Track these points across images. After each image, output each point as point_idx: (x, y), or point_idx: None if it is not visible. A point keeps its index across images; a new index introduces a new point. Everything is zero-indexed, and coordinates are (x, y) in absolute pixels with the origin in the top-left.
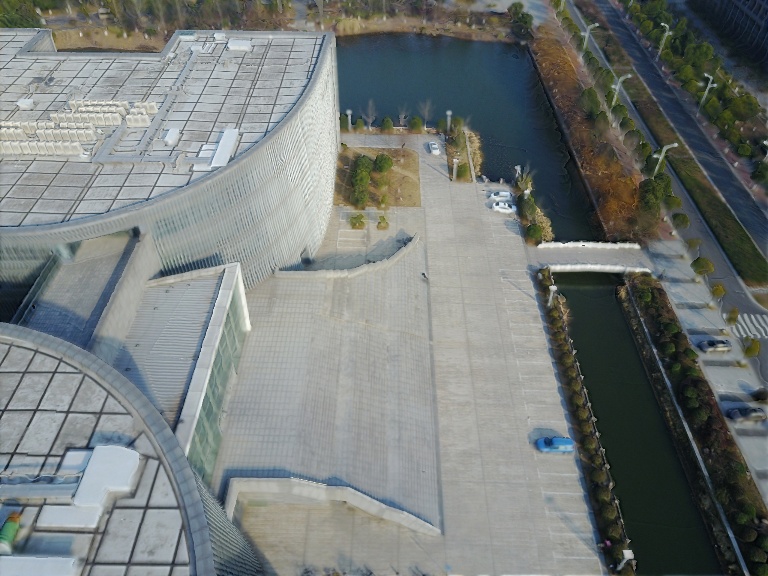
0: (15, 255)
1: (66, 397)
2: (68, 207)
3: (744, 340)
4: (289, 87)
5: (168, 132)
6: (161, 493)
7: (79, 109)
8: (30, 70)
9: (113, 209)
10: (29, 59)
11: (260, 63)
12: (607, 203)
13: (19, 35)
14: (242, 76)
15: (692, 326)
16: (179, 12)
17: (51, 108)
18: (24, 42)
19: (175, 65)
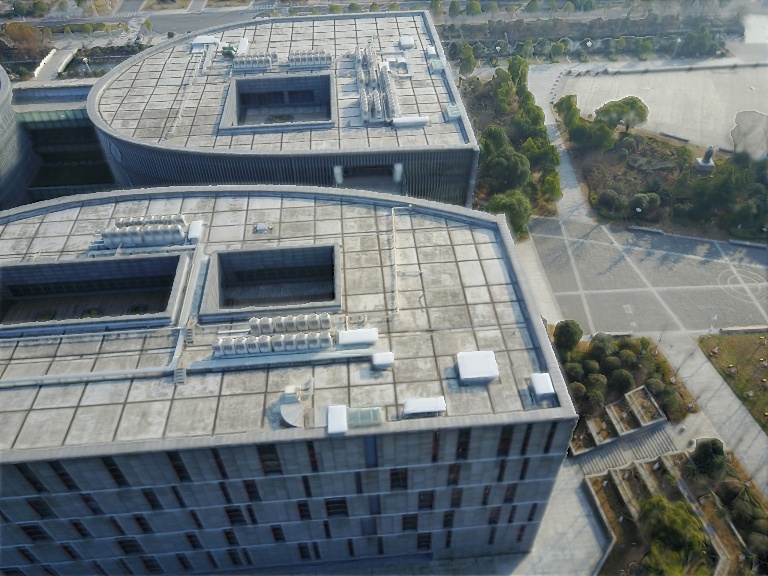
0: (7, 124)
1: (159, 59)
2: None
3: (143, 26)
4: None
5: None
6: (216, 35)
7: None
8: None
9: None
10: None
11: None
12: (8, 54)
13: None
14: None
15: (123, 45)
16: None
17: None
18: None
19: None
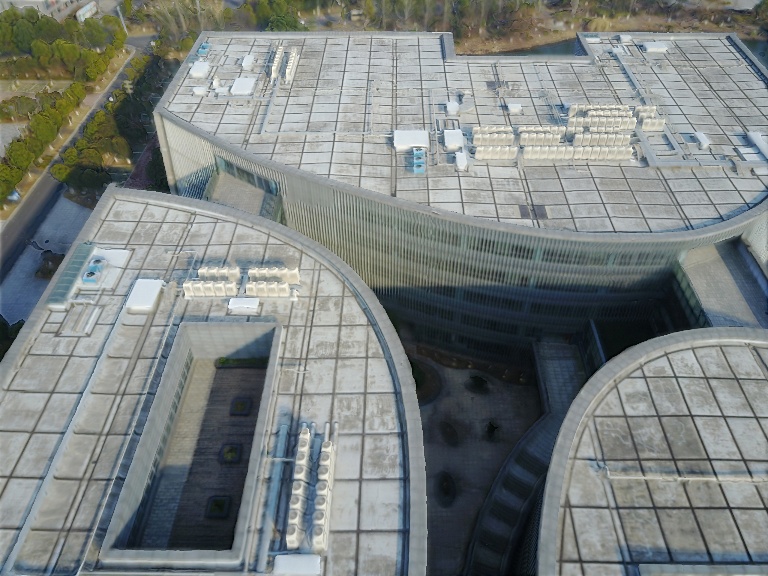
0: (643, 260)
1: None
2: (676, 212)
3: None
4: (751, 89)
5: (697, 136)
6: None
7: (591, 113)
8: (473, 74)
9: (725, 214)
10: (460, 63)
11: (691, 65)
12: None
13: (421, 39)
14: (689, 78)
15: None
16: (445, 13)
17: (541, 112)
18: (435, 46)
19: (609, 68)
